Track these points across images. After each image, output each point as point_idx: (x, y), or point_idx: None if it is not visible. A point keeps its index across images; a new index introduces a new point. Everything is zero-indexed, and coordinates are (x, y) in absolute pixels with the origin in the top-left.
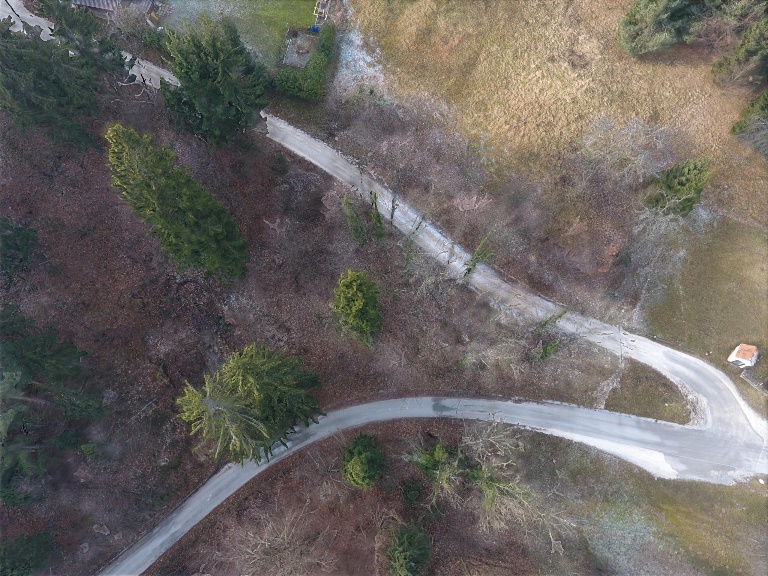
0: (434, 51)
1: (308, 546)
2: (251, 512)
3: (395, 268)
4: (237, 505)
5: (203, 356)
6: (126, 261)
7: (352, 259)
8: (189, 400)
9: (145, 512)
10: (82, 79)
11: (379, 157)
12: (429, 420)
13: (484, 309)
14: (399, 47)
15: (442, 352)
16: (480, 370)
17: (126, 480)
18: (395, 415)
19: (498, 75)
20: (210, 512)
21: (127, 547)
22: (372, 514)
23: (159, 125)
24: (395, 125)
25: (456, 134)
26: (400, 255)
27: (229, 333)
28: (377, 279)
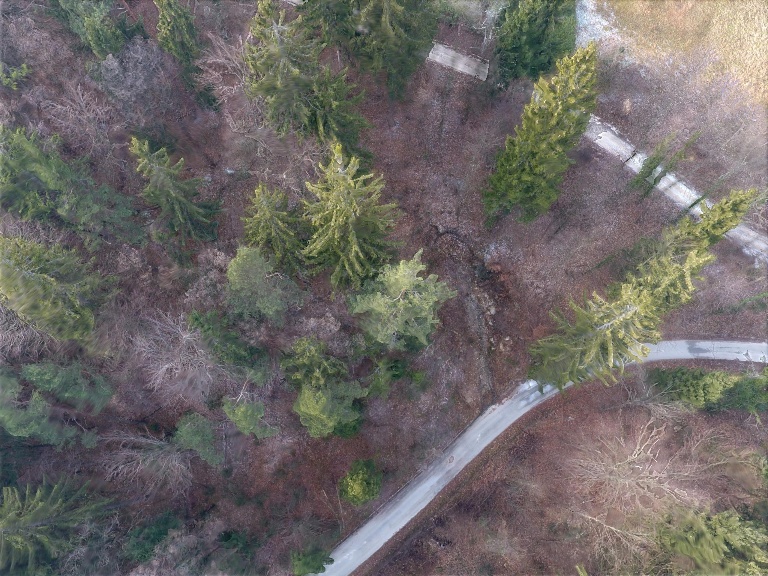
0: (668, 15)
1: (625, 470)
2: (518, 451)
3: (647, 218)
4: (507, 444)
5: (462, 303)
6: (397, 211)
7: (601, 210)
8: (620, 305)
9: (426, 449)
10: (431, 25)
11: (622, 114)
12: (687, 361)
13: (736, 255)
14: (633, 11)
15: (697, 297)
16: (734, 313)
17: (413, 418)
18: (652, 357)
19: (732, 36)
20: (481, 451)
21: (404, 485)
22: (687, 438)
23: (417, 84)
24: (638, 83)
25: (697, 91)
26: (651, 205)
27: (489, 281)
28: (628, 229)
